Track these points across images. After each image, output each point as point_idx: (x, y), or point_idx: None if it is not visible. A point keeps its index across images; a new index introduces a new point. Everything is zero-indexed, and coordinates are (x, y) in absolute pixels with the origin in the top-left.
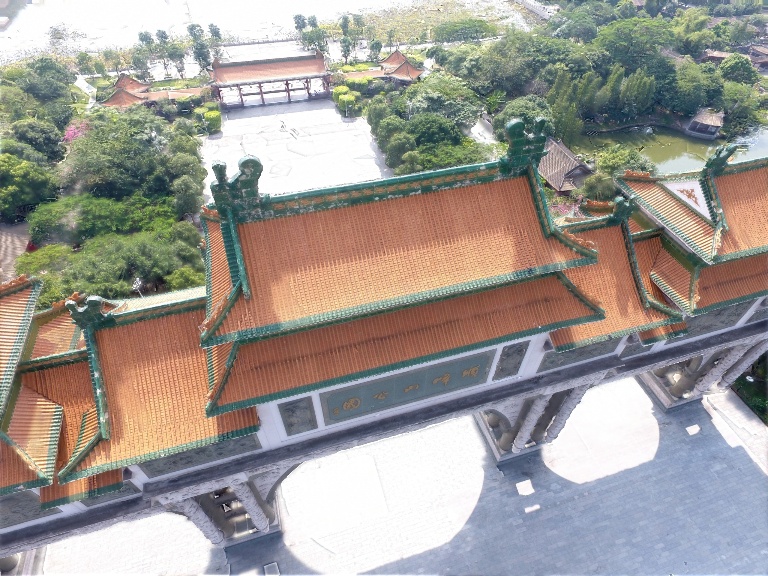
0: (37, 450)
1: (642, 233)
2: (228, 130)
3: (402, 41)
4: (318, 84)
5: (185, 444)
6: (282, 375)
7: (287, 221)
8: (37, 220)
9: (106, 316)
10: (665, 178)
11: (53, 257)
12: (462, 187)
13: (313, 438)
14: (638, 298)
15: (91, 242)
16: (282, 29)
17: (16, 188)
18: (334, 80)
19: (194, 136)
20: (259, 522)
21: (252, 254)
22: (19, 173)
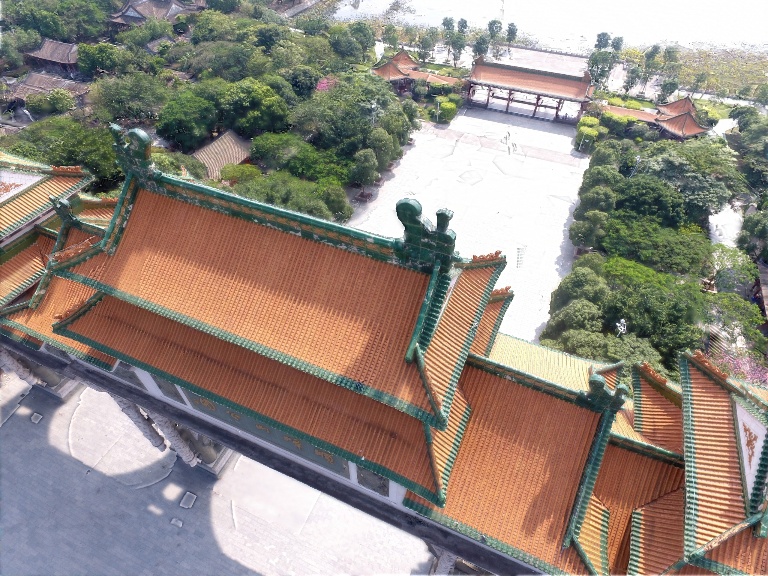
0: (3, 289)
1: (651, 448)
2: (456, 124)
3: (710, 89)
4: (576, 108)
5: (67, 345)
6: (121, 336)
7: (175, 204)
8: (256, 143)
9: (74, 219)
10: (746, 395)
11: (245, 174)
12: (348, 251)
13: (187, 412)
14: (565, 524)
15: (274, 174)
16: (581, 44)
17: (259, 114)
18: (590, 109)
19: (417, 119)
20: (179, 453)
21: (136, 219)
22: (266, 103)
